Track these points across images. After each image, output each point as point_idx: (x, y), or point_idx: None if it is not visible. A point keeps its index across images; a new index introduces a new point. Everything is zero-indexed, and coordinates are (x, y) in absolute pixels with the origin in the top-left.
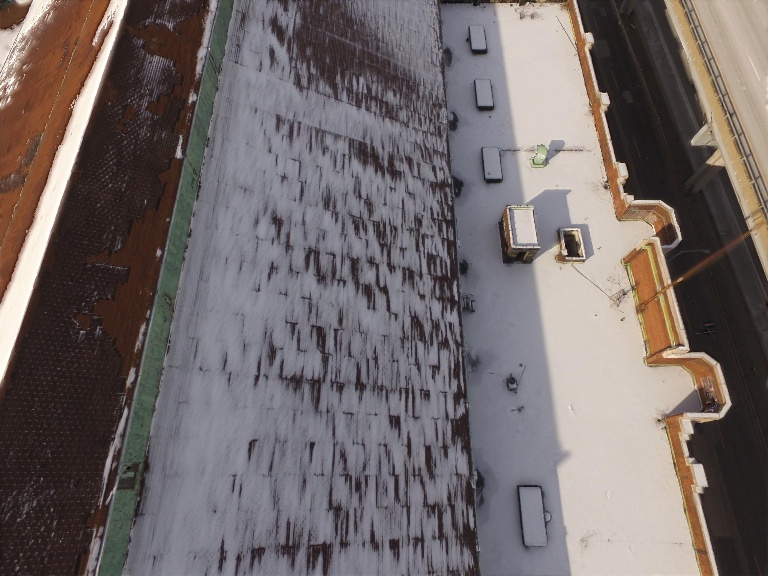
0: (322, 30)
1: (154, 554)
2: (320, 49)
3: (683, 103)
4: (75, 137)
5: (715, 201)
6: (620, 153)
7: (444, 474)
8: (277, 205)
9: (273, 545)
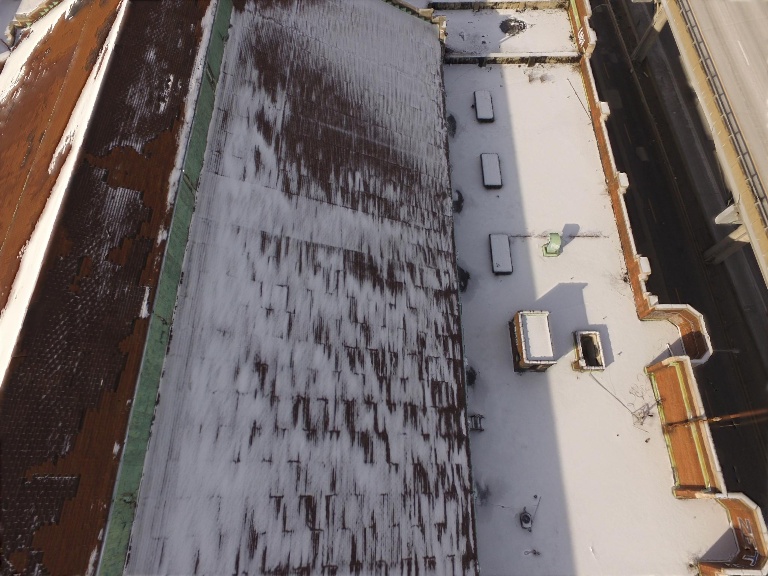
0: (314, 120)
1: None
2: (312, 144)
3: (701, 161)
4: (19, 305)
5: (737, 272)
6: (635, 217)
7: None
8: (261, 346)
9: None
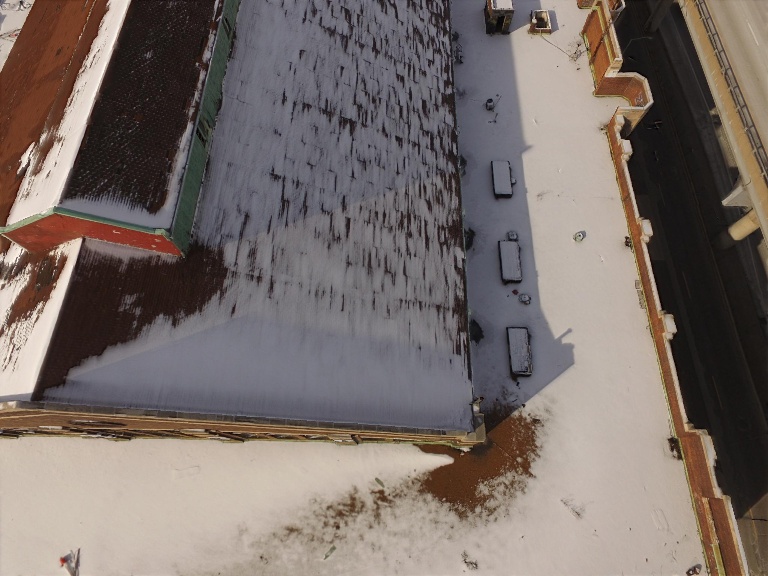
0: None
1: (242, 80)
2: None
3: None
4: None
5: (670, 39)
6: None
7: (435, 119)
8: None
9: (317, 106)
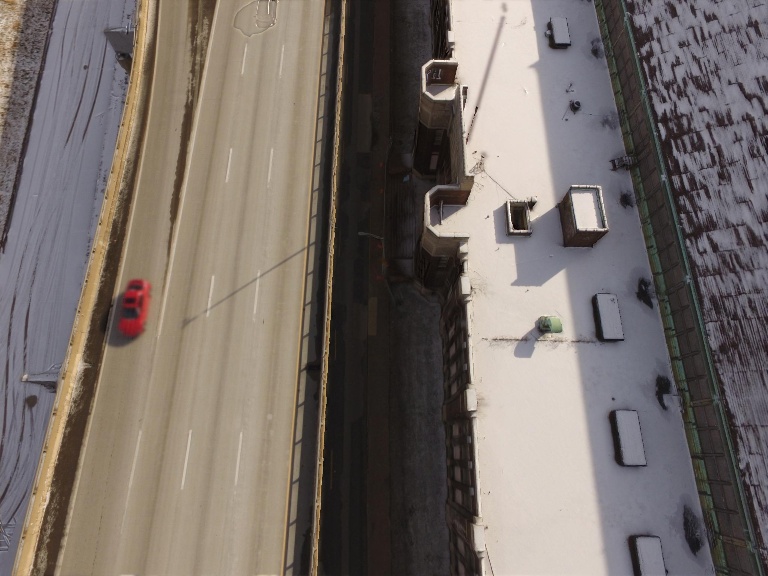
0: None
1: None
2: None
3: None
4: None
5: None
6: (356, 459)
7: (657, 9)
8: None
9: None
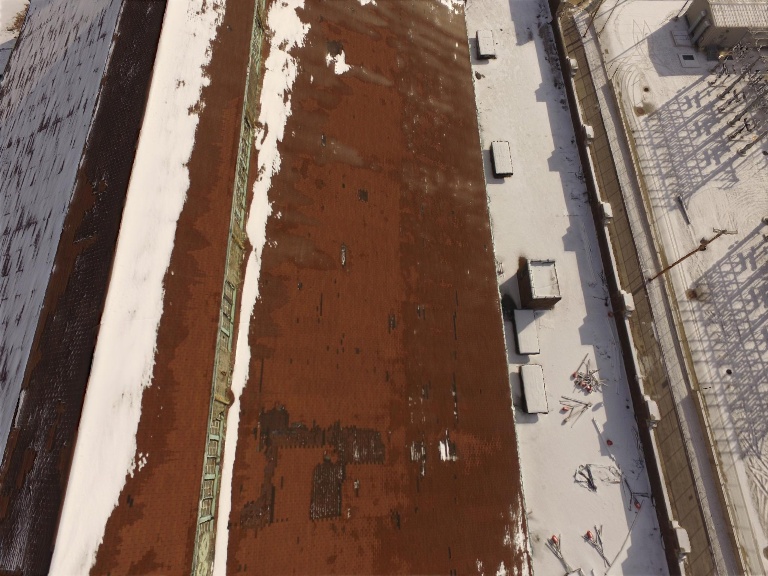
0: None
1: None
2: None
3: None
4: (108, 383)
5: None
6: None
7: None
8: None
9: None
